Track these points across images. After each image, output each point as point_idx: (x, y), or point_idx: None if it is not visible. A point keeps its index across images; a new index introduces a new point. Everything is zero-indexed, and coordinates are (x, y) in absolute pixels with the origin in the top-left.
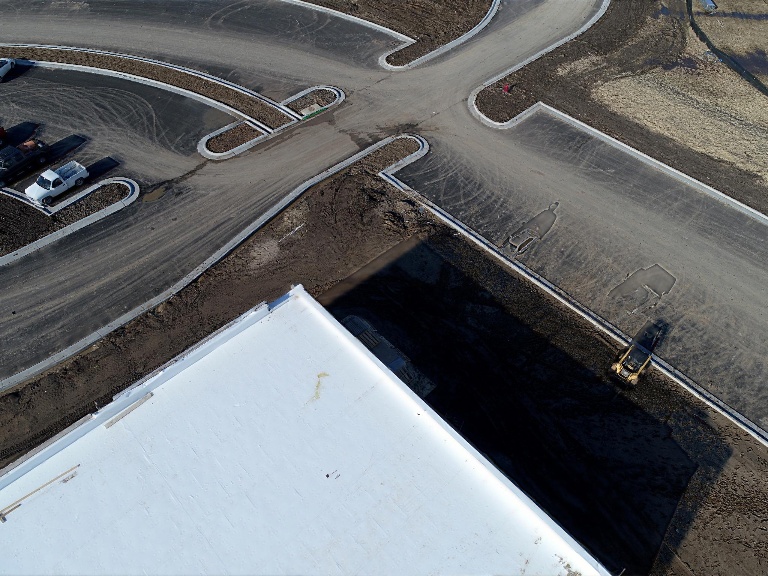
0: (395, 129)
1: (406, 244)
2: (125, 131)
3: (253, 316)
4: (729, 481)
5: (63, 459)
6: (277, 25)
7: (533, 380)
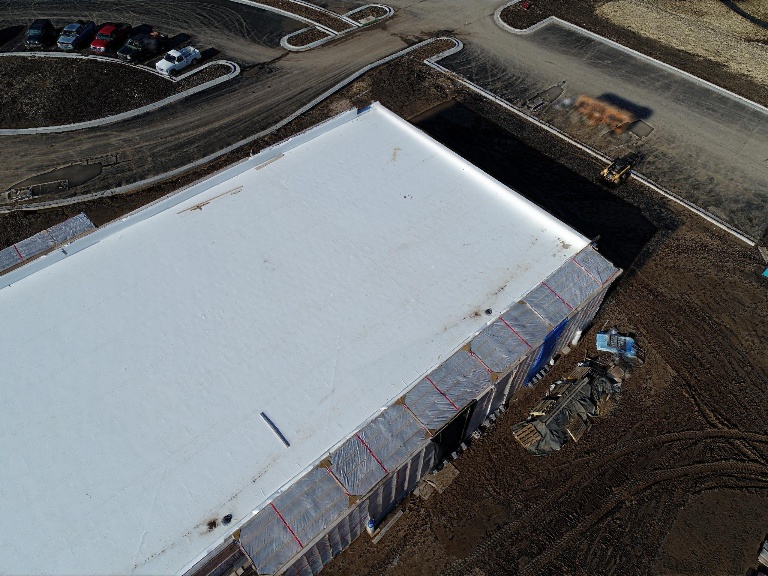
0: (436, 33)
1: (447, 103)
2: (222, 31)
3: (348, 113)
4: (681, 238)
5: (231, 183)
6: None
7: (543, 181)
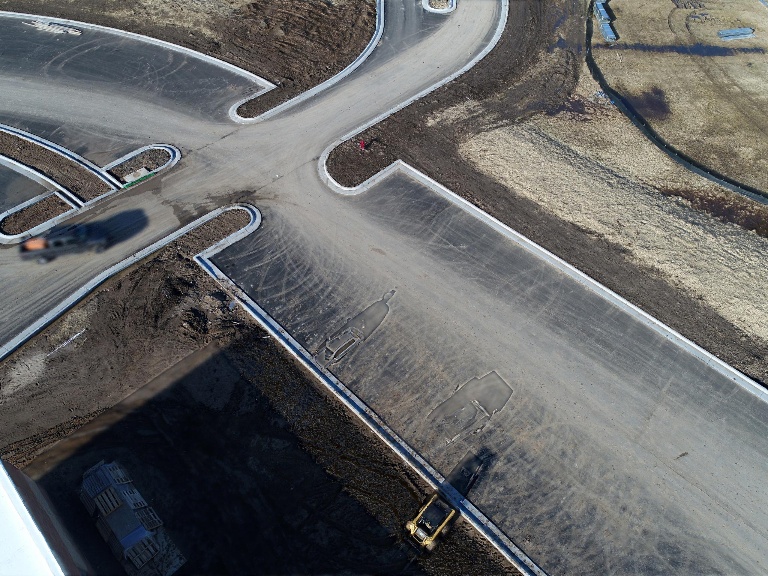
0: (228, 198)
1: (200, 354)
2: None
3: None
4: None
5: None
6: (124, 69)
7: (309, 546)
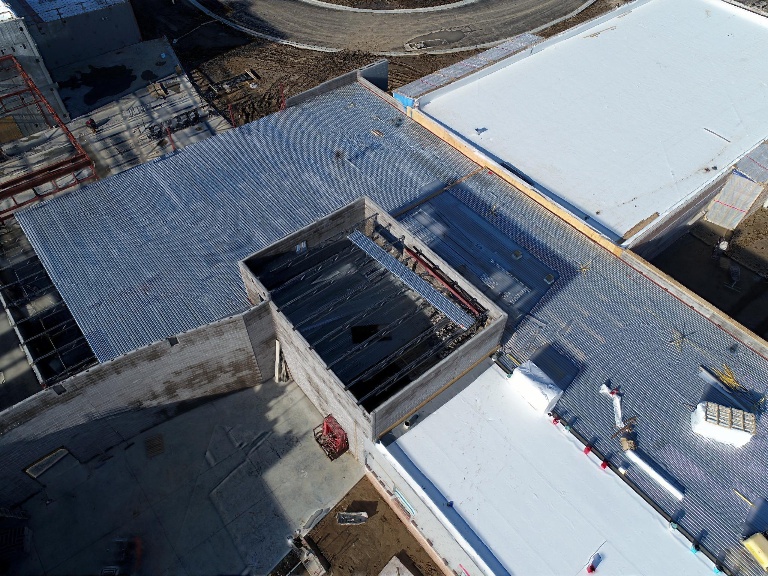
0: None
1: None
2: None
3: None
4: None
5: (607, 24)
6: None
7: None
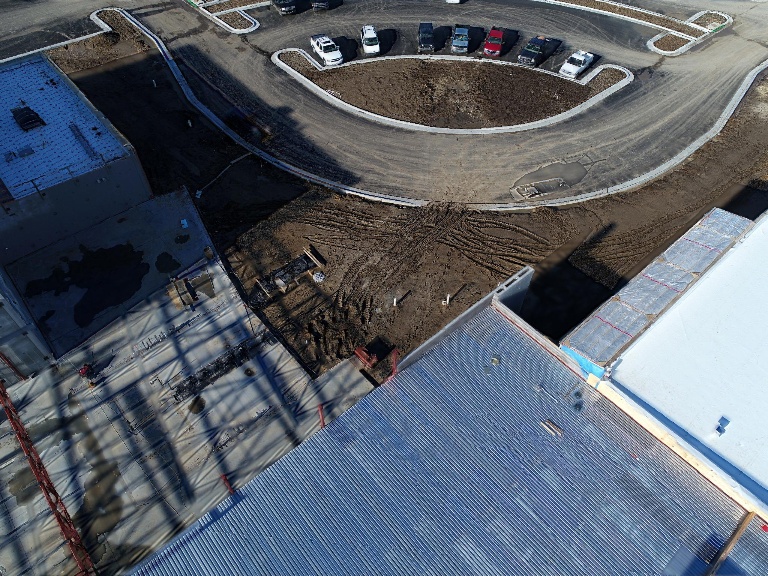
0: None
1: None
2: (585, 36)
3: None
4: None
5: None
6: None
7: None
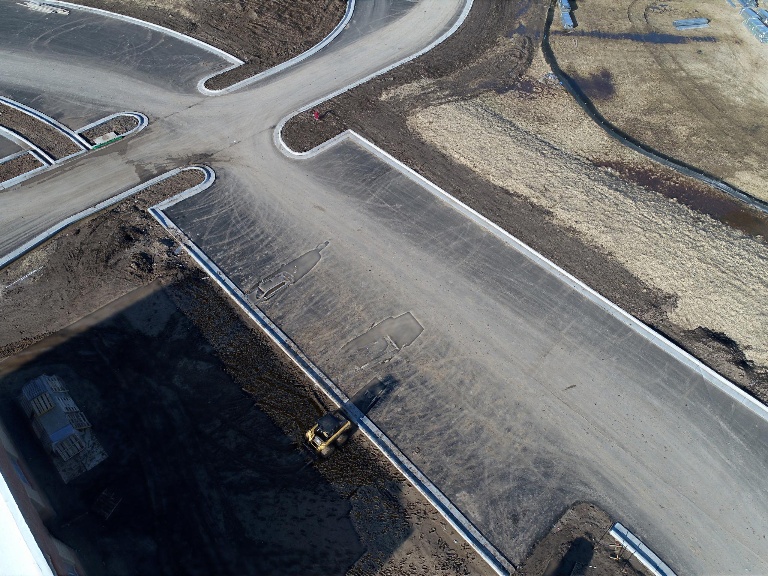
0: (186, 160)
1: (143, 290)
2: None
3: None
4: (395, 569)
5: None
6: (105, 46)
7: (218, 449)
